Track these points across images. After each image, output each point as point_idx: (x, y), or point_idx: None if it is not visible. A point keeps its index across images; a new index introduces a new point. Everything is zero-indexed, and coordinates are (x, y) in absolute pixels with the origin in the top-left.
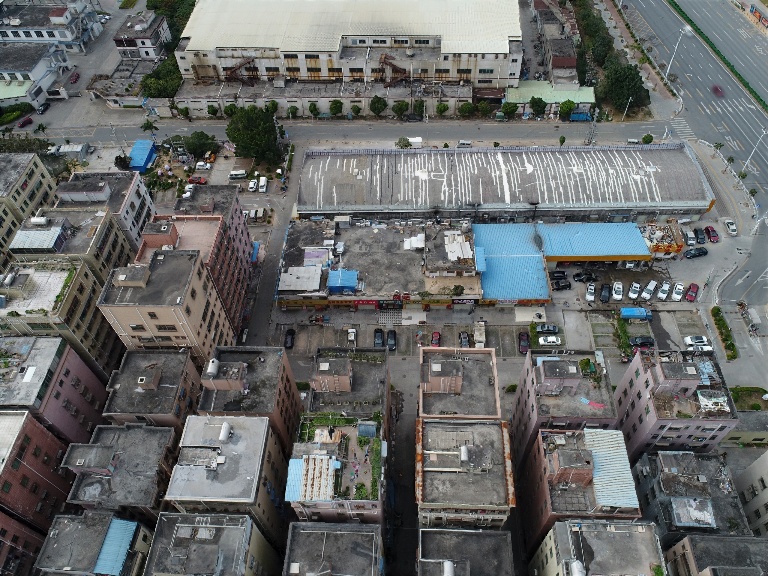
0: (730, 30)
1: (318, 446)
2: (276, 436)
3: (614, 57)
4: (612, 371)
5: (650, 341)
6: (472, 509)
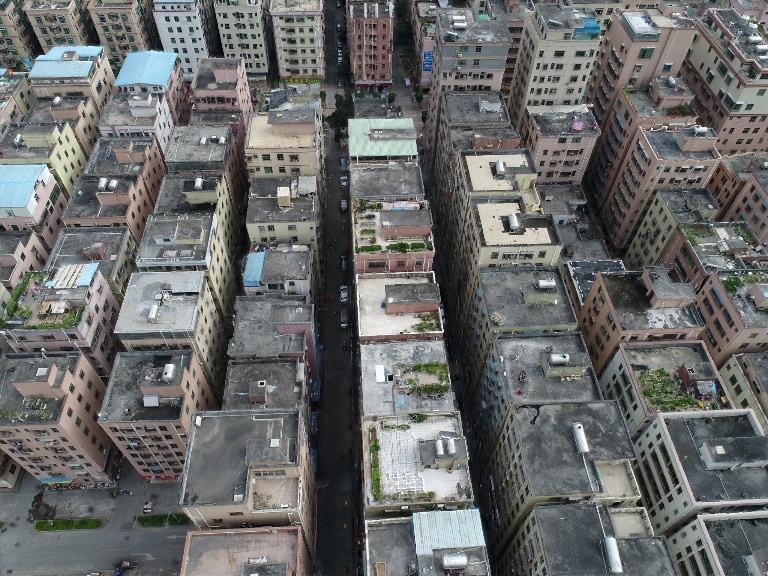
0: None
1: (63, 297)
2: None
3: None
4: None
5: None
6: None
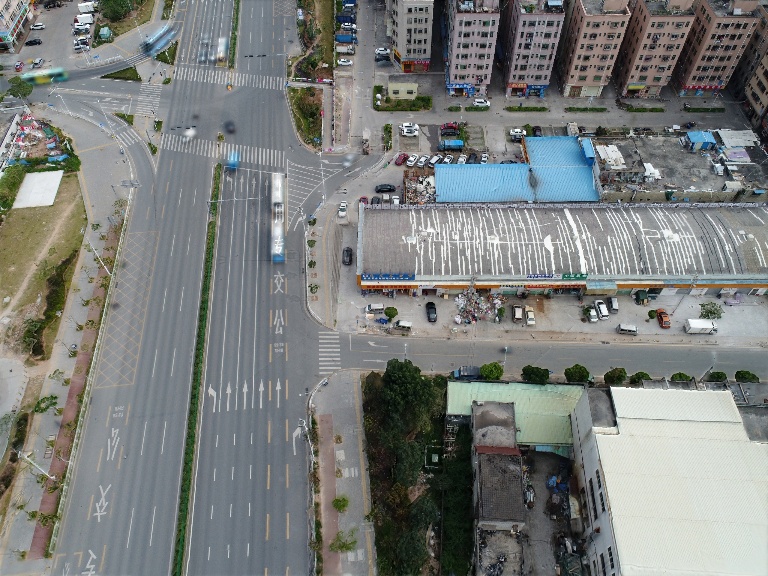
0: None
1: None
2: (694, 9)
3: (407, 463)
4: (474, 119)
5: (445, 130)
6: None
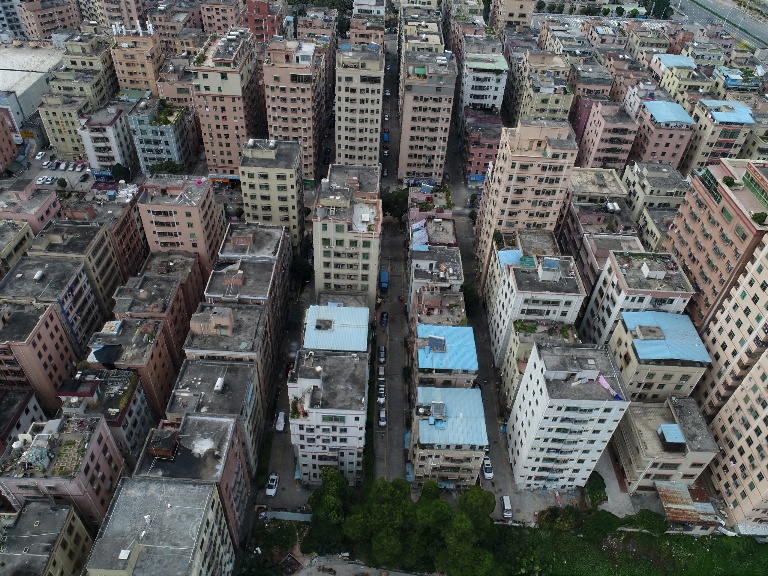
0: (705, 0)
1: None
2: None
3: None
4: None
5: None
6: (657, 43)
